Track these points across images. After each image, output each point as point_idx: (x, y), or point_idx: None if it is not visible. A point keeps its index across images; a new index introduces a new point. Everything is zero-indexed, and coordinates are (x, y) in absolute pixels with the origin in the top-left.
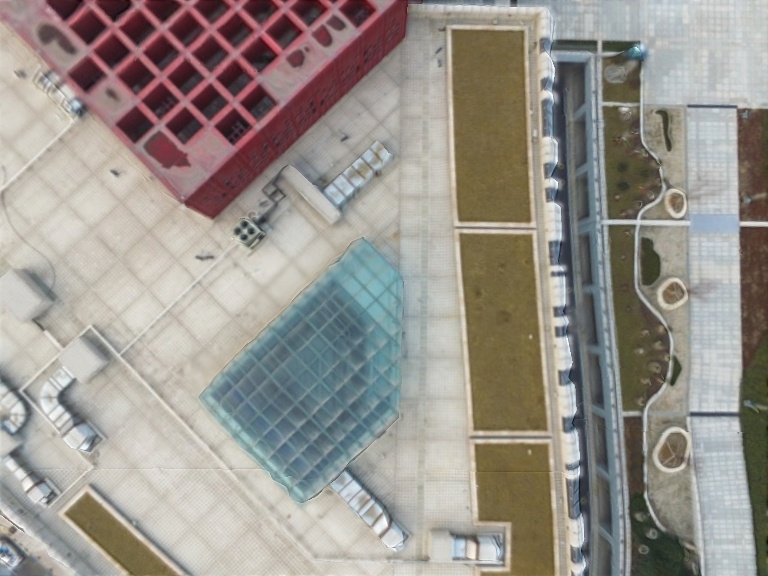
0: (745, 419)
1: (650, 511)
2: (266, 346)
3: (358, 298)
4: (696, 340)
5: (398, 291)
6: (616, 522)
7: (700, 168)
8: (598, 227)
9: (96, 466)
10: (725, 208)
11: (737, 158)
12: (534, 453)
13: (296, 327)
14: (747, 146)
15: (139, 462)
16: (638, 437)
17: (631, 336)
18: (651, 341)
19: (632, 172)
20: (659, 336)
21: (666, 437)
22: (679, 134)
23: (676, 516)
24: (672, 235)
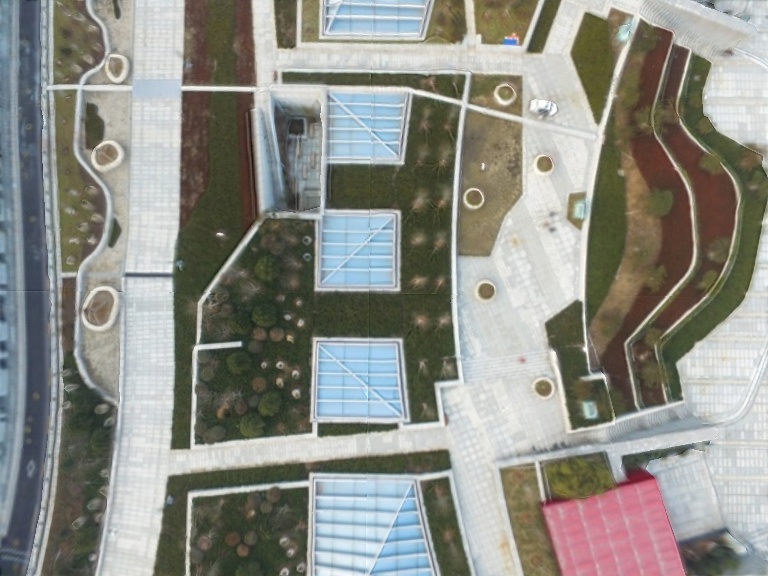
0: (177, 279)
1: (79, 369)
2: None
3: None
4: (135, 202)
5: None
6: None
7: (147, 35)
8: (44, 93)
9: None
10: (169, 73)
11: (183, 25)
12: None
13: None
14: (194, 13)
15: None
16: (71, 296)
17: (67, 198)
18: (81, 201)
19: (76, 38)
20: (89, 196)
21: (93, 295)
22: (129, 2)
23: (111, 375)
24: (118, 101)
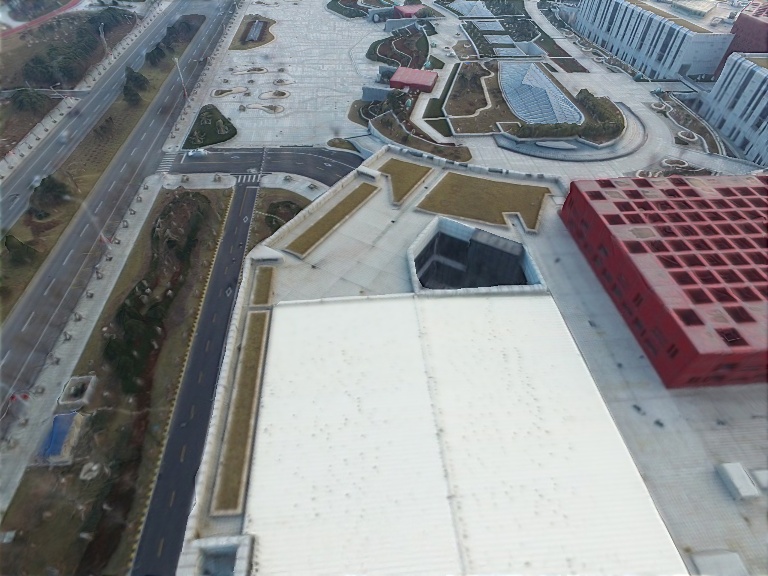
0: None
1: None
2: (711, 5)
3: (698, 7)
4: None
5: (690, 7)
6: None
7: None
8: None
9: (728, 4)
10: None
11: None
12: (634, 3)
13: (708, 6)
14: None
15: (719, 5)
16: None
17: None
18: None
19: None
20: None
21: None
22: None
23: None
24: None
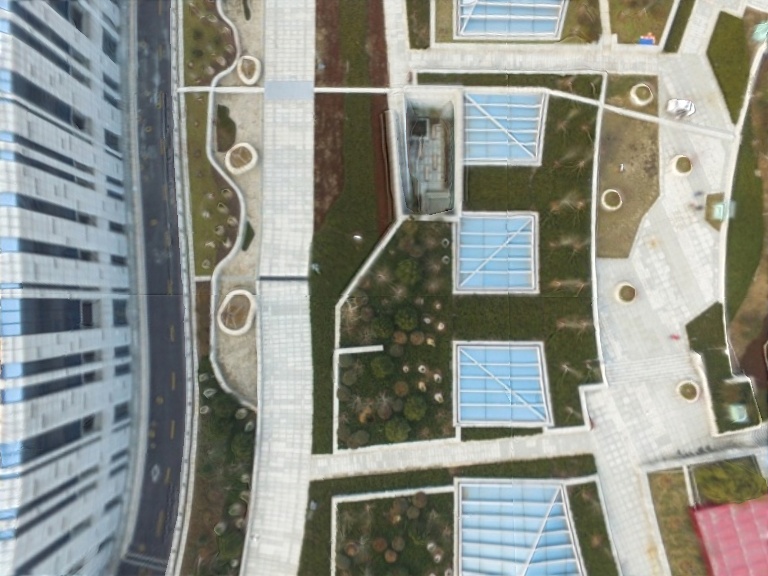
0: (313, 282)
1: (215, 373)
2: None
3: None
4: (268, 205)
5: None
6: (186, 385)
7: (278, 36)
8: (174, 95)
9: None
10: (301, 75)
11: (315, 26)
12: None
13: None
14: (325, 14)
15: None
16: (205, 300)
17: (201, 201)
18: (216, 204)
19: (207, 40)
20: (224, 199)
21: (230, 299)
22: (259, 3)
23: (246, 379)
24: (249, 103)
